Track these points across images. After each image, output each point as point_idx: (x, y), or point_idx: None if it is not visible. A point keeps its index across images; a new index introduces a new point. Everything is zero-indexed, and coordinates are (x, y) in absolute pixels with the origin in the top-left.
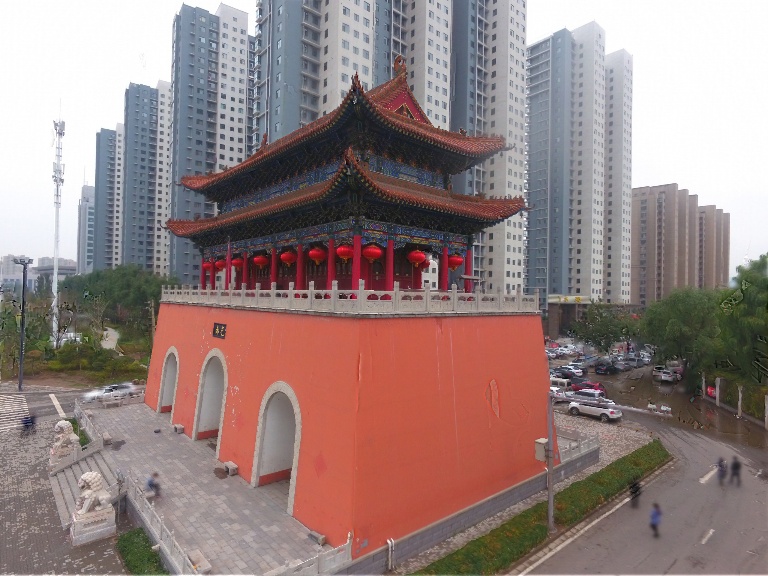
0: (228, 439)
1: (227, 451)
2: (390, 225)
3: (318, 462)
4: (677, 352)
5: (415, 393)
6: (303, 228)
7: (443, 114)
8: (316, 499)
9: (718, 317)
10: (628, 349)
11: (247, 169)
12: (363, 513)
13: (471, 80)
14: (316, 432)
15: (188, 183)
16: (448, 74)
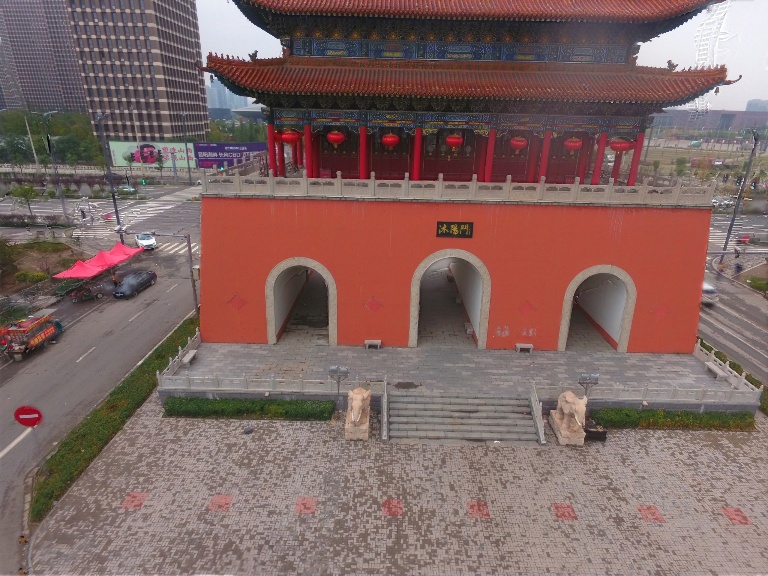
0: None
1: None
2: None
3: None
4: None
5: None
6: None
7: None
8: None
9: None
10: None
11: None
12: None
13: None
14: None
15: None
16: None
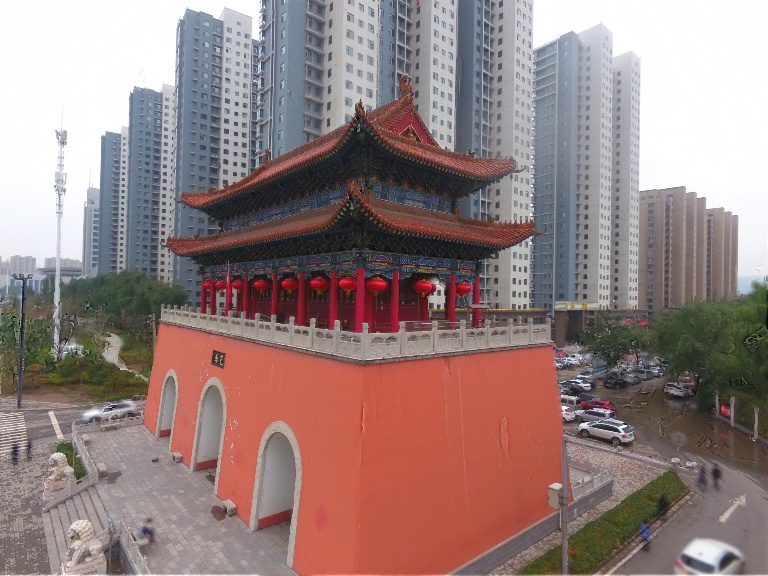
0: (226, 475)
1: (225, 488)
2: (395, 255)
3: (319, 514)
4: (689, 368)
5: (422, 440)
6: (305, 256)
7: (448, 120)
8: (317, 554)
9: (733, 336)
10: (637, 361)
11: (247, 191)
12: (367, 574)
13: (477, 85)
14: (317, 481)
15: (188, 200)
16: (453, 79)
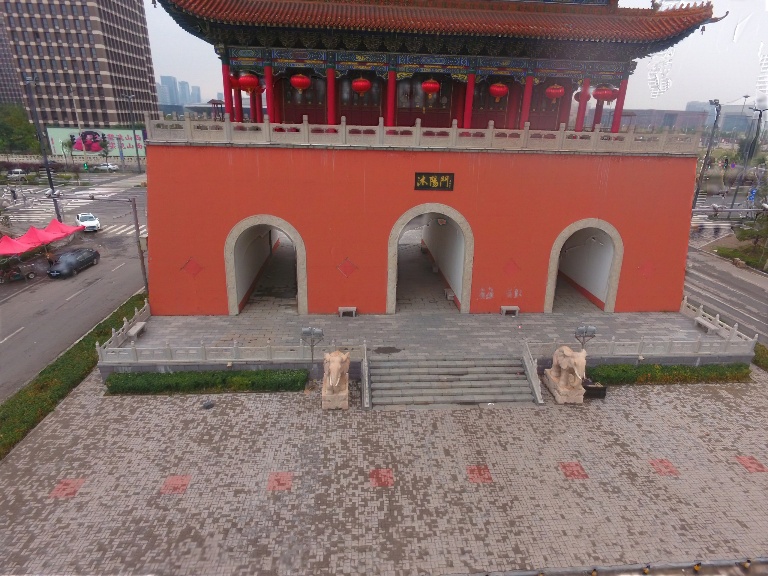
0: None
1: None
2: None
3: None
4: None
5: None
6: None
7: None
8: None
9: None
10: None
11: None
12: None
13: None
14: None
15: None
16: None
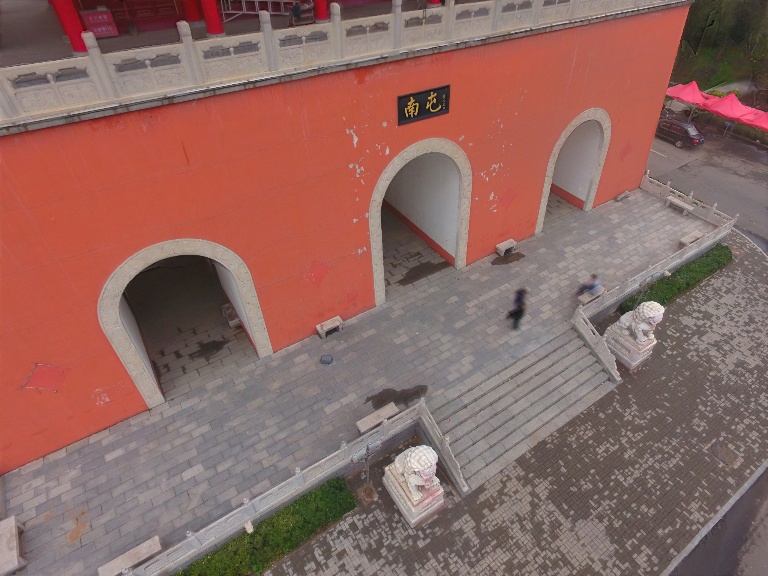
0: (485, 232)
1: (484, 244)
2: None
3: None
4: None
5: None
6: None
7: None
8: None
9: None
10: None
11: None
12: None
13: None
14: None
15: None
16: None
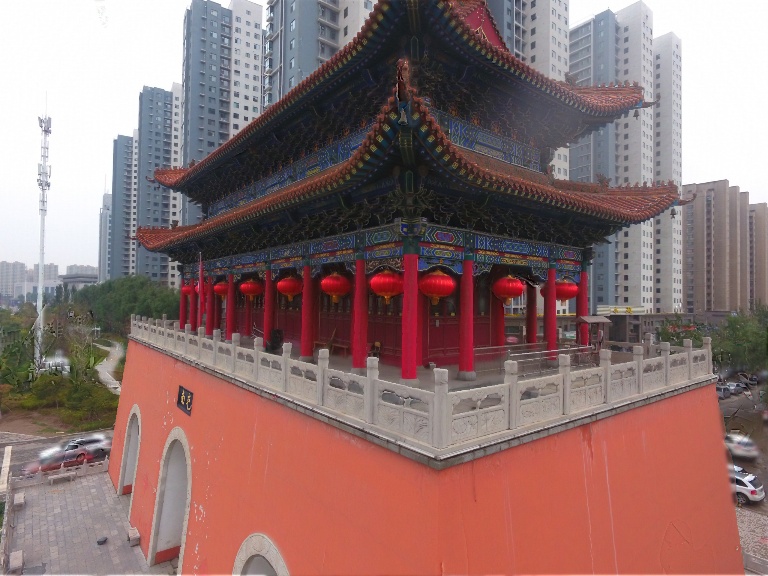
0: None
1: None
2: (467, 233)
3: None
4: None
5: None
6: (311, 239)
7: None
8: None
9: None
10: None
11: (230, 150)
12: None
13: None
14: None
15: (163, 178)
16: None
